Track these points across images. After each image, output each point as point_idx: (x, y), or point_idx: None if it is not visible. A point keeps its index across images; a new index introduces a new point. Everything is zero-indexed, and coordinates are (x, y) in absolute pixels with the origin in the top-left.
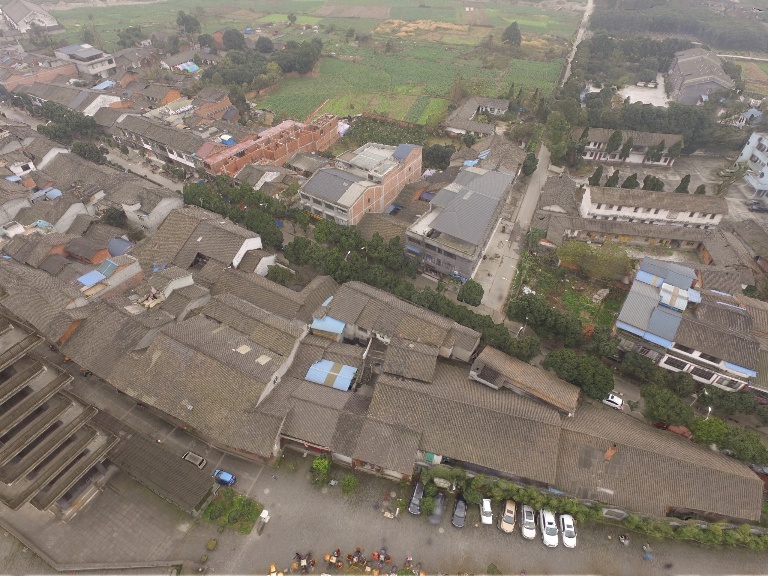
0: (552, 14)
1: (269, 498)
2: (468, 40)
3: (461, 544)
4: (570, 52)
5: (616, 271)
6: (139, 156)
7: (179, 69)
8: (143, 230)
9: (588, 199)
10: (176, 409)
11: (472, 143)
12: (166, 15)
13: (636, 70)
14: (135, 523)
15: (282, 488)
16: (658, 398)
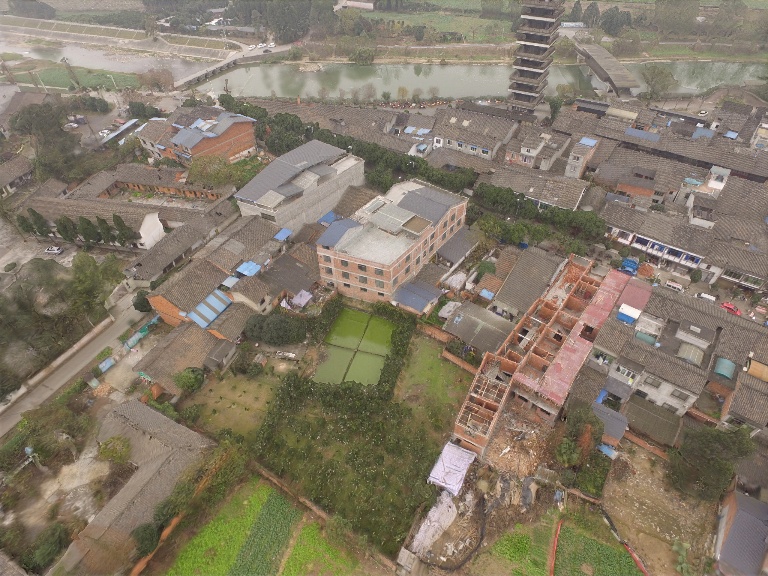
0: None
1: None
2: None
3: None
4: None
5: None
6: None
7: None
8: None
9: (152, 223)
10: None
11: None
12: None
13: None
14: None
15: None
16: None
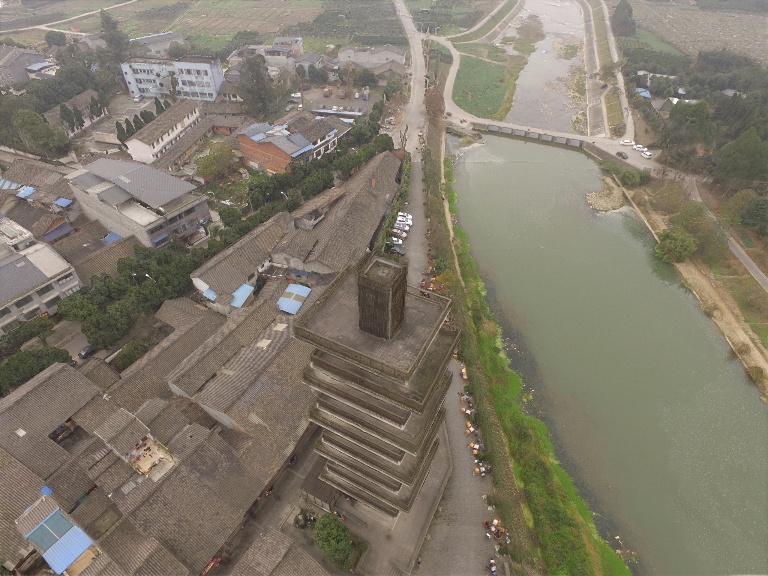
0: None
1: None
2: None
3: (413, 254)
4: None
5: (228, 159)
6: None
7: None
8: None
9: (140, 148)
10: None
11: None
12: None
13: None
14: None
15: None
16: (343, 161)
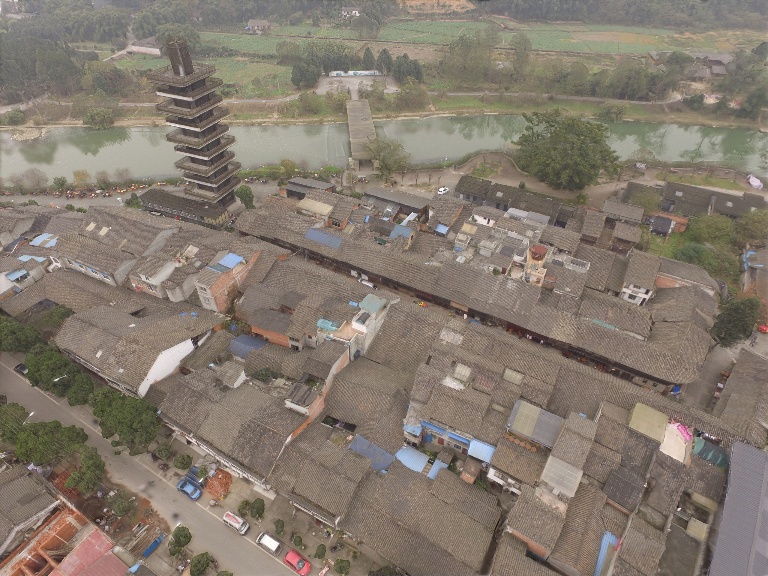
0: None
1: None
2: None
3: None
4: None
5: None
6: None
7: None
8: None
9: None
10: None
11: None
12: None
13: None
14: None
15: None
16: None
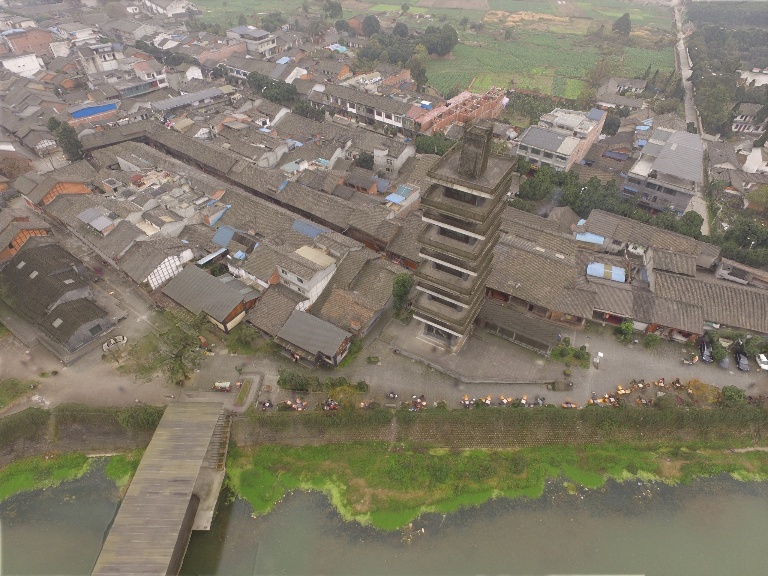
0: (643, 8)
1: (591, 349)
2: (574, 30)
3: (751, 381)
4: (678, 42)
5: None
6: (340, 119)
7: (330, 50)
8: (386, 173)
9: (756, 158)
10: (504, 287)
11: (627, 115)
12: (283, 4)
13: (749, 58)
14: (504, 358)
15: (598, 343)
16: None
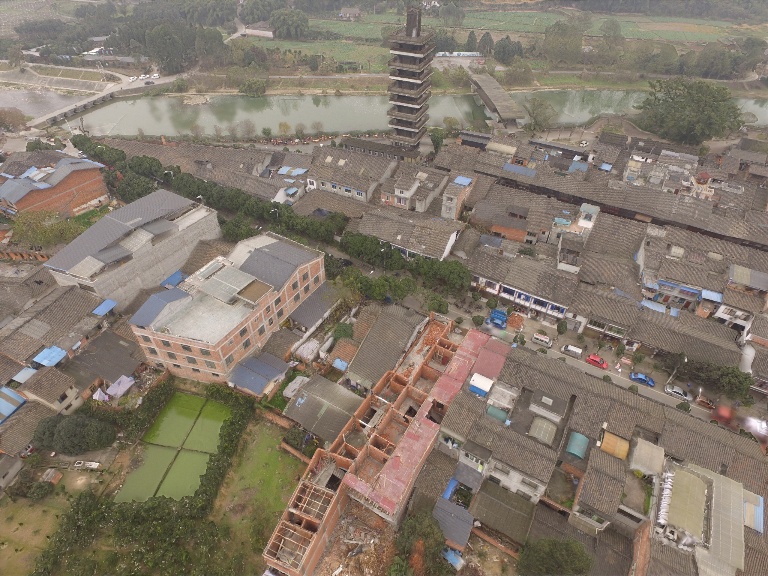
0: None
1: None
2: None
3: None
4: None
5: None
6: None
7: None
8: None
9: None
10: None
11: None
12: None
13: None
14: None
15: None
16: (119, 152)
